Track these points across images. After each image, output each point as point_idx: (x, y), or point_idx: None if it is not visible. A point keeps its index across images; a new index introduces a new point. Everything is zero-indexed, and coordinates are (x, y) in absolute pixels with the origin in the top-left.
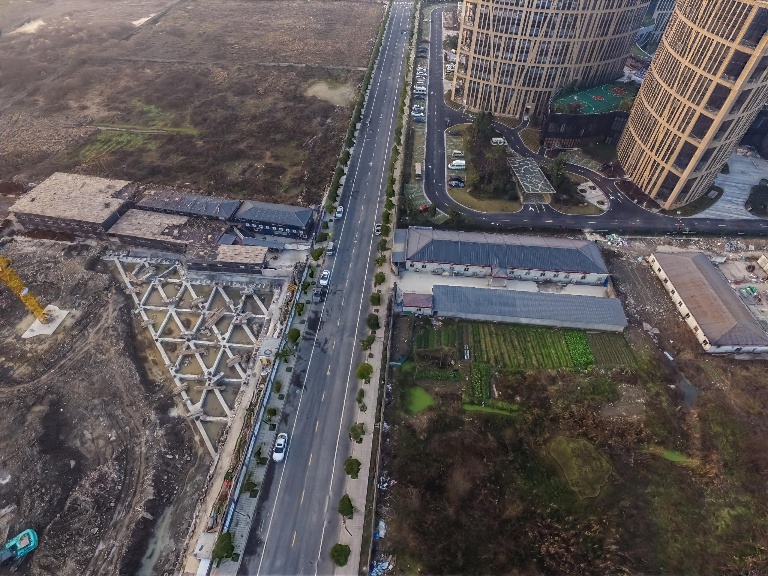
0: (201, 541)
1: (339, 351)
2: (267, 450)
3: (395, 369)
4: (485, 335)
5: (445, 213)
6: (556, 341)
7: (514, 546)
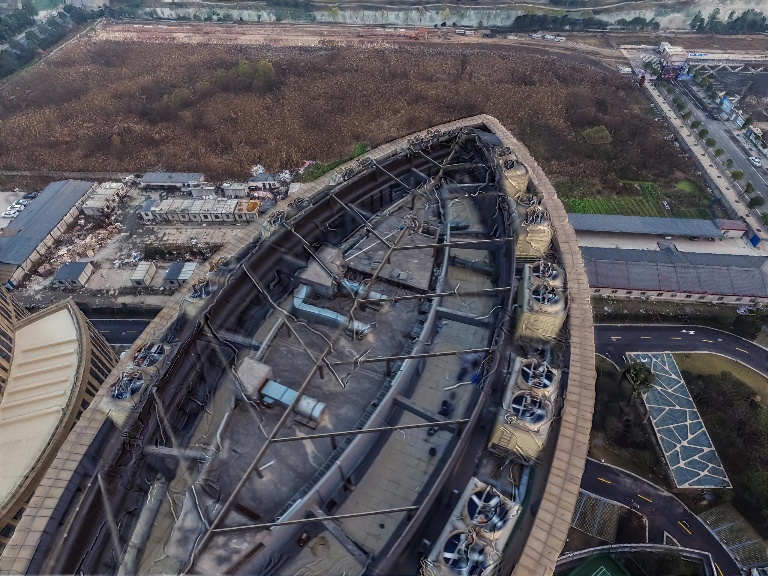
0: (760, 131)
1: (764, 204)
2: (761, 162)
3: (713, 198)
4: (656, 216)
5: (767, 351)
6: (598, 213)
7: (615, 136)
